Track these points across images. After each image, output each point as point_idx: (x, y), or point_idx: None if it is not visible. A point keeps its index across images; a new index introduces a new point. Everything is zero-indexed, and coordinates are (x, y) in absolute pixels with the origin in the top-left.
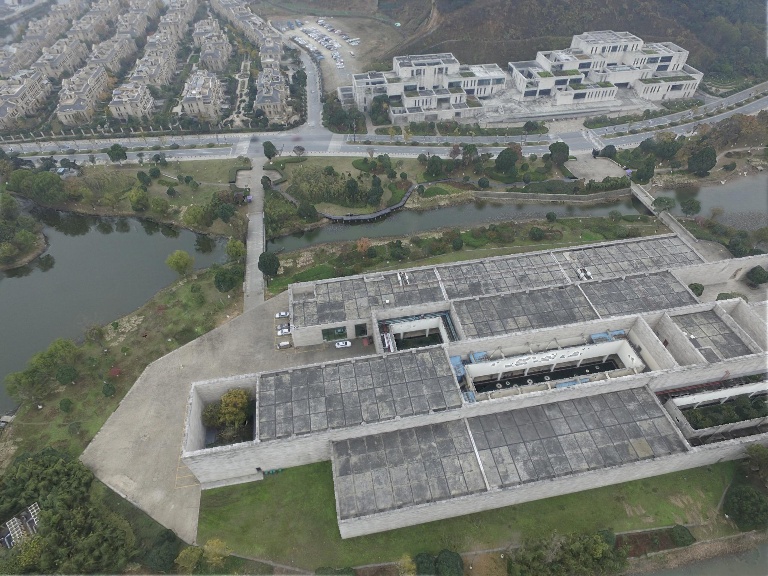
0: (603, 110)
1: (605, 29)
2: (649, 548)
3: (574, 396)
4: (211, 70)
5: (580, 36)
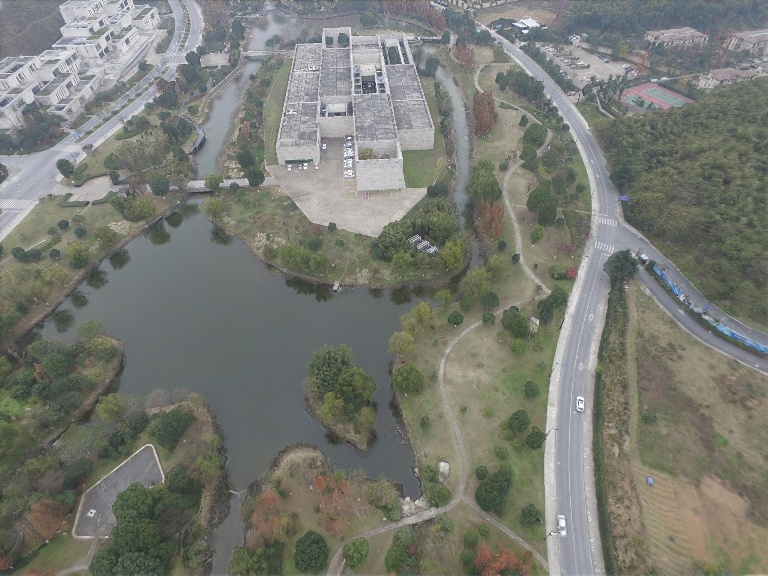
0: (148, 43)
1: None
2: None
3: None
4: None
5: (63, 9)
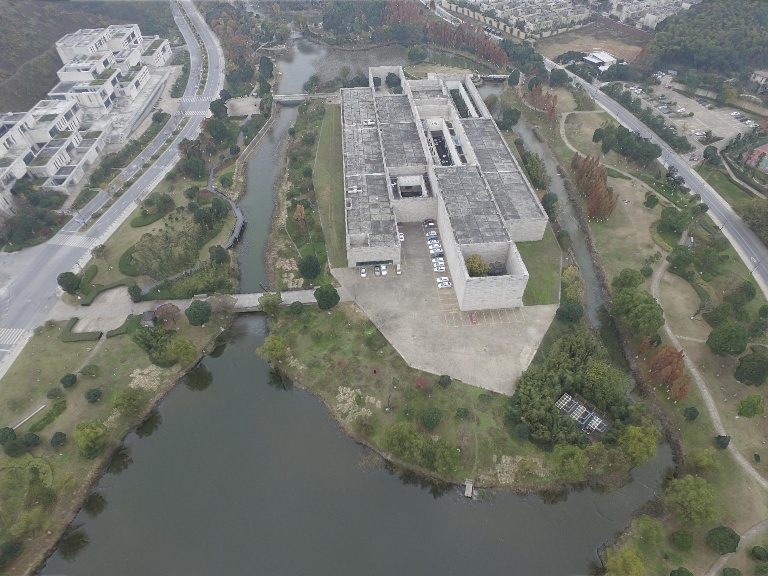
0: (161, 85)
1: None
2: None
3: None
4: None
5: None
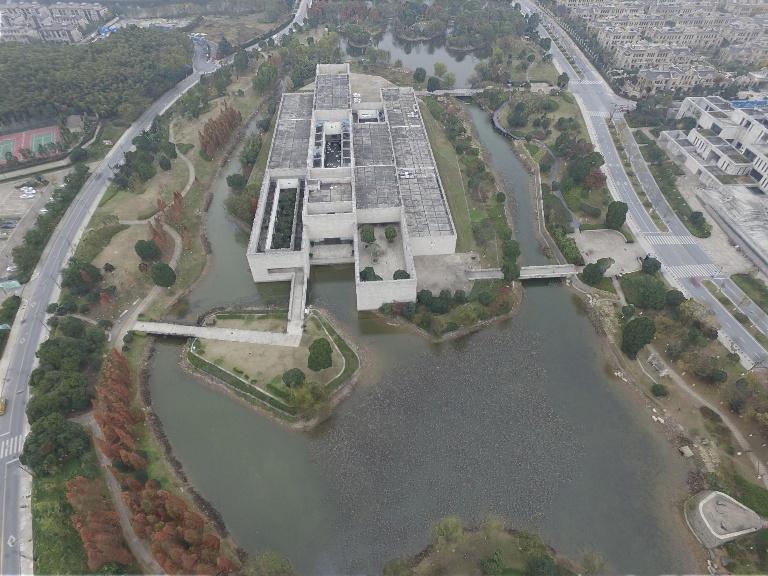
0: None
1: None
2: None
3: None
4: (718, 60)
5: None
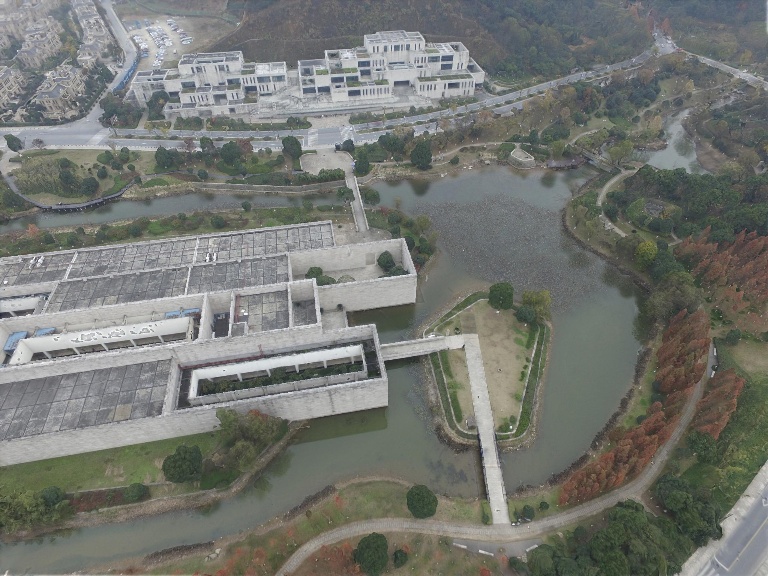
0: (375, 107)
1: (407, 29)
2: (102, 504)
3: (95, 367)
4: (28, 67)
5: (370, 36)
